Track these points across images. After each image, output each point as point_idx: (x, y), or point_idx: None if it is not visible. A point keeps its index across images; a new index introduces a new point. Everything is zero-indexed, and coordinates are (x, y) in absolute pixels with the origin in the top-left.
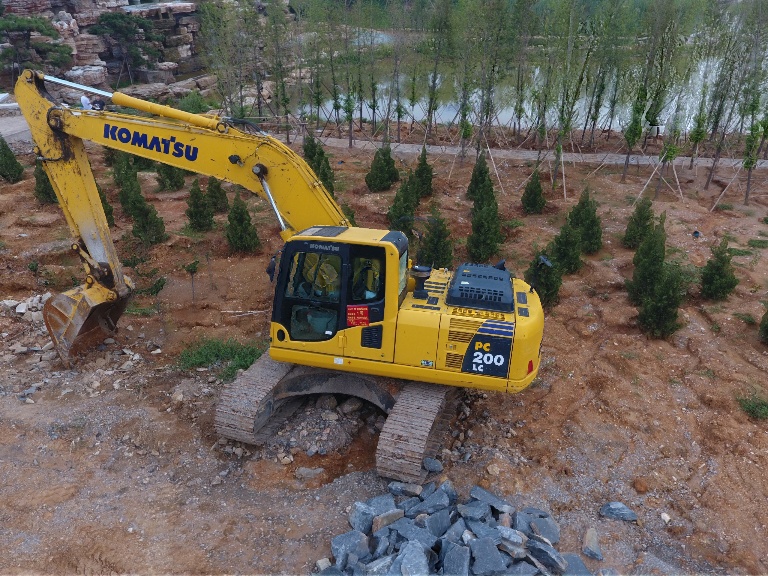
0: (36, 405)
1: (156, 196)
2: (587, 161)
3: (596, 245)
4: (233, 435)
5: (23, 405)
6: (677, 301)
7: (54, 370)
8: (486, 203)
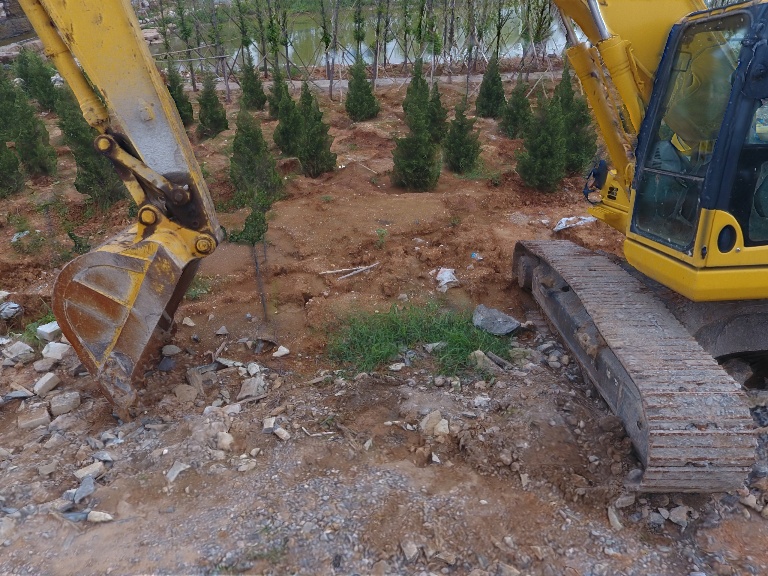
0: (121, 523)
1: (66, 148)
2: (556, 77)
3: None
4: (690, 483)
5: (85, 532)
6: None
7: (94, 430)
8: (523, 112)
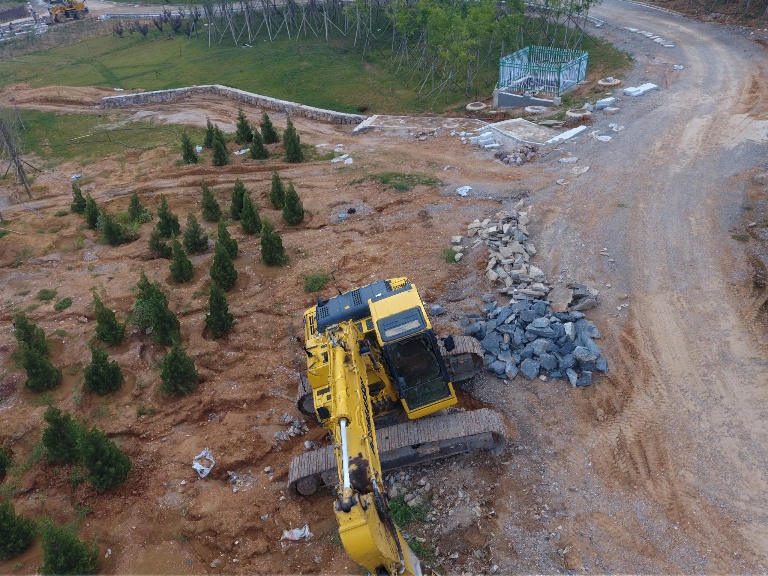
0: None
1: None
2: None
3: (59, 370)
4: None
5: None
6: (224, 299)
7: None
8: None
